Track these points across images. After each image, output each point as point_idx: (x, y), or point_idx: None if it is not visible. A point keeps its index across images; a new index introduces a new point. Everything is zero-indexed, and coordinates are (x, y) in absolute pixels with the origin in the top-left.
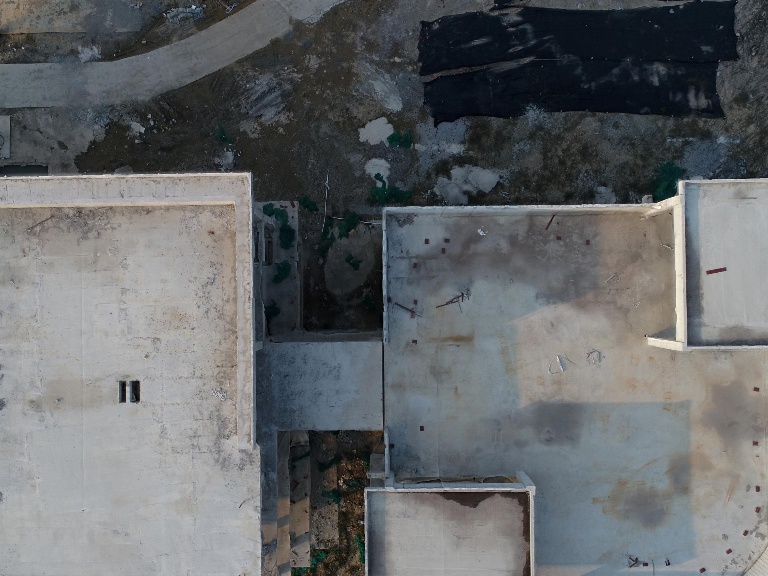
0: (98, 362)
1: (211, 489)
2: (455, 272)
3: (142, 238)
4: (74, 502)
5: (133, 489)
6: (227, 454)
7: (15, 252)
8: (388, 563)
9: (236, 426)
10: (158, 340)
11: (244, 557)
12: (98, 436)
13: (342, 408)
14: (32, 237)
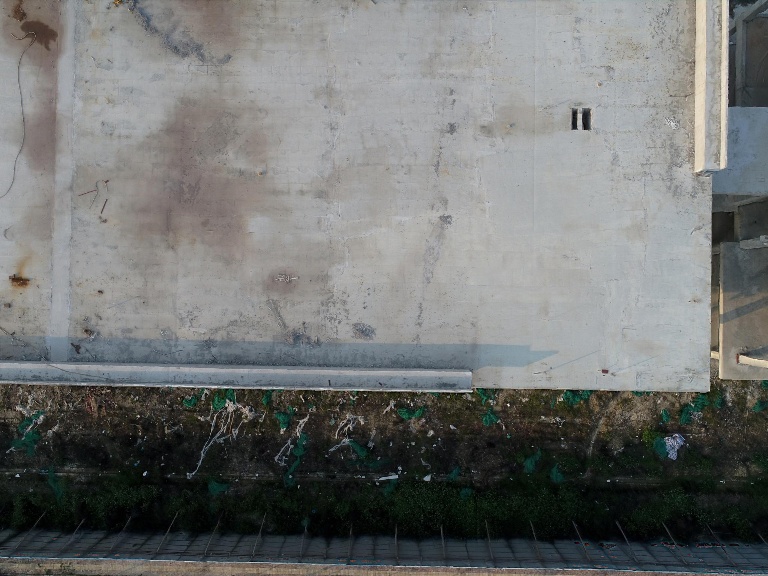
0: (551, 89)
1: (662, 216)
2: None
3: None
4: (524, 226)
5: (584, 215)
6: (679, 182)
7: None
8: None
9: (689, 154)
10: (612, 69)
11: (694, 283)
12: (549, 162)
13: (739, 171)
14: None
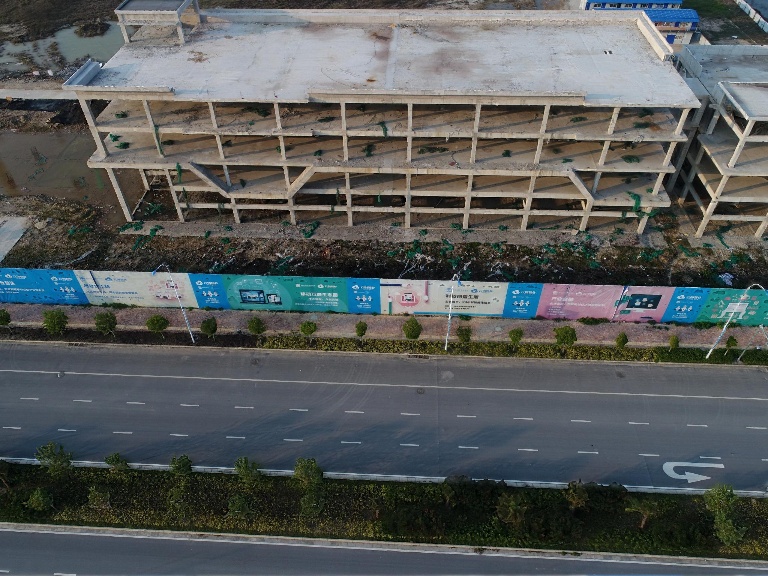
0: None
1: (654, 69)
2: (719, 65)
3: None
4: None
5: None
6: None
7: (551, 30)
8: (741, 99)
9: None
10: None
11: None
12: (599, 59)
13: None
14: (557, 28)
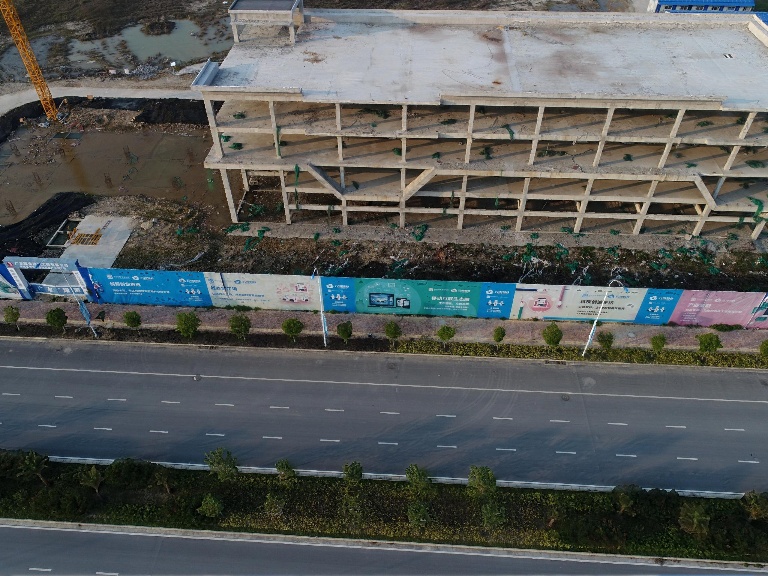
0: None
1: None
2: None
3: (712, 32)
4: None
5: None
6: None
7: (663, 33)
8: None
9: None
10: None
11: None
12: (722, 63)
13: None
14: (668, 31)
